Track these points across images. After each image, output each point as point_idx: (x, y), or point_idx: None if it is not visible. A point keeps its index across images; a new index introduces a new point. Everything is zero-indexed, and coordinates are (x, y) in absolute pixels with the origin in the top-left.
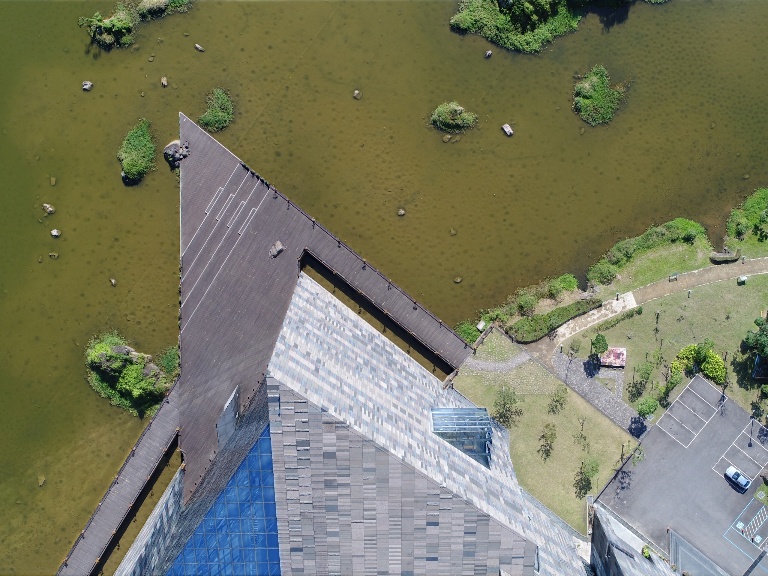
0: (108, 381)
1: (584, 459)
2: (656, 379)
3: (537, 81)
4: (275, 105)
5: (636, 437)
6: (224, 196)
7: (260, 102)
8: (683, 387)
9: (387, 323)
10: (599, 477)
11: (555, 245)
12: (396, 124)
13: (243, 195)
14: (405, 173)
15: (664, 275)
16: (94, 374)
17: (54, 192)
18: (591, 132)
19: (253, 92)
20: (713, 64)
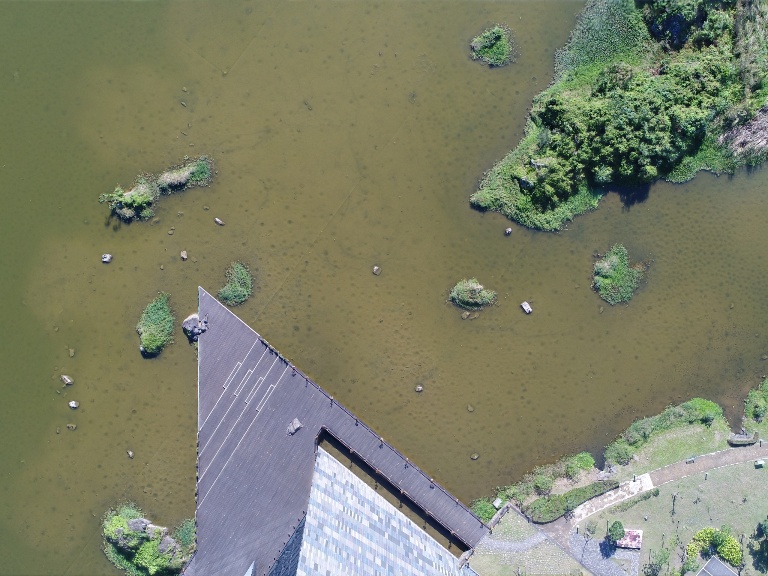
0: (124, 554)
1: None
2: (672, 560)
3: (556, 259)
4: (294, 280)
5: None
6: (242, 371)
7: (279, 276)
8: (699, 568)
9: (403, 499)
10: None
11: (572, 423)
12: (415, 300)
13: (261, 371)
14: (423, 349)
15: (681, 457)
16: (110, 546)
17: (72, 363)
18: (610, 311)
19: (272, 266)
20: (733, 244)
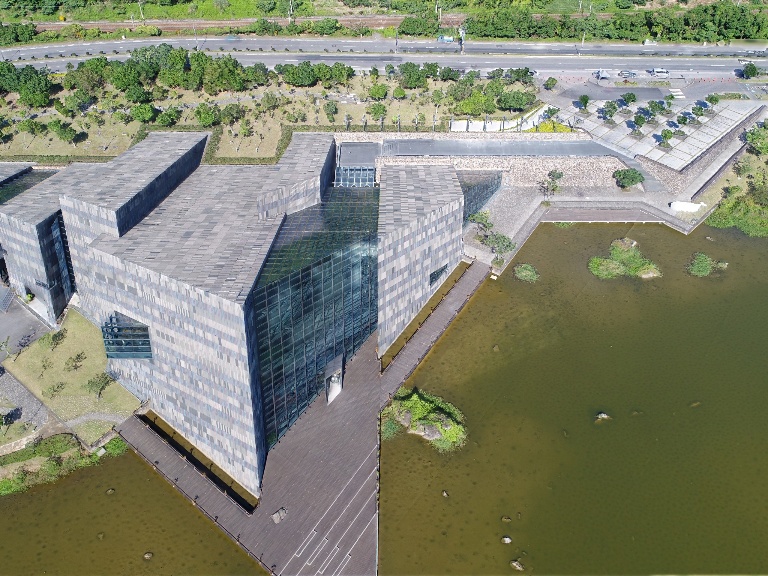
0: (445, 413)
1: None
2: None
3: None
4: None
5: (2, 367)
6: (330, 572)
7: None
8: None
9: (189, 456)
10: None
11: (4, 522)
12: None
13: (310, 572)
14: None
15: None
16: (459, 419)
17: None
18: None
19: None
20: None
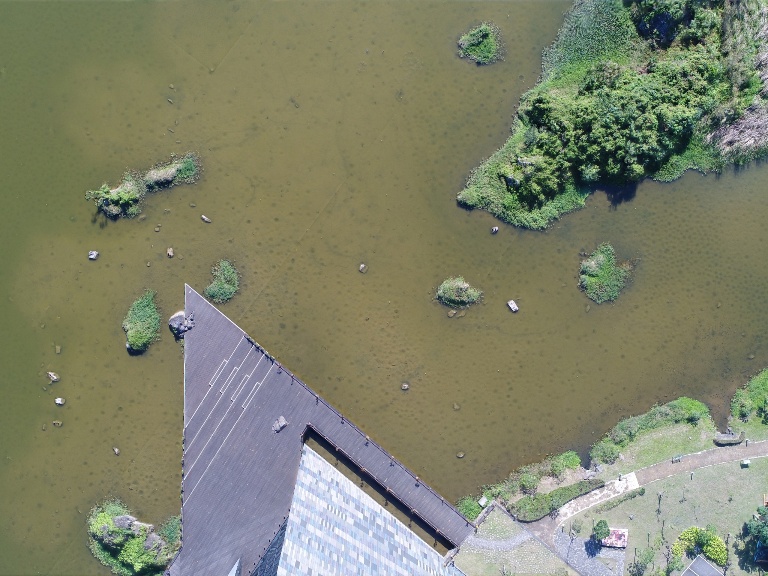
0: (110, 550)
1: None
2: (657, 560)
3: (543, 257)
4: (281, 277)
5: None
6: (228, 369)
7: (266, 274)
8: (684, 568)
9: (389, 497)
10: None
11: (558, 422)
12: (401, 298)
13: (247, 369)
14: (409, 347)
15: (667, 456)
16: (96, 542)
17: (59, 360)
18: (596, 309)
19: (259, 264)
20: (720, 243)
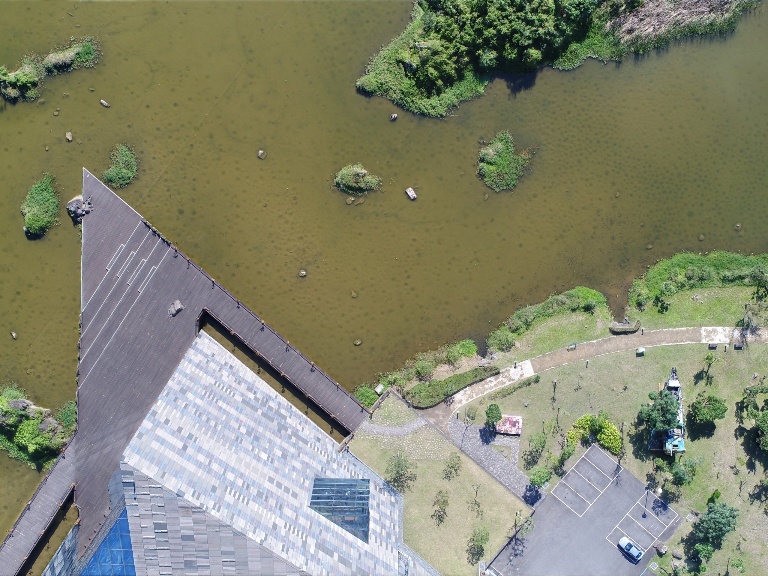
0: (6, 434)
1: (475, 527)
2: (552, 448)
3: (442, 145)
4: (179, 163)
5: (530, 505)
6: (125, 253)
7: (164, 159)
8: (579, 456)
9: (286, 384)
10: (492, 544)
11: (456, 310)
12: (300, 185)
13: (144, 253)
14: (307, 234)
15: (563, 344)
16: None
17: None
18: (495, 198)
19: (157, 149)
20: (619, 133)
